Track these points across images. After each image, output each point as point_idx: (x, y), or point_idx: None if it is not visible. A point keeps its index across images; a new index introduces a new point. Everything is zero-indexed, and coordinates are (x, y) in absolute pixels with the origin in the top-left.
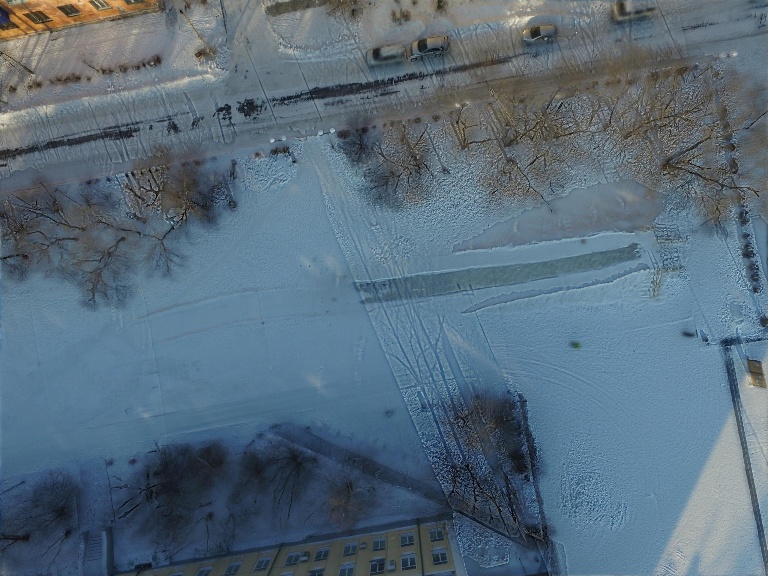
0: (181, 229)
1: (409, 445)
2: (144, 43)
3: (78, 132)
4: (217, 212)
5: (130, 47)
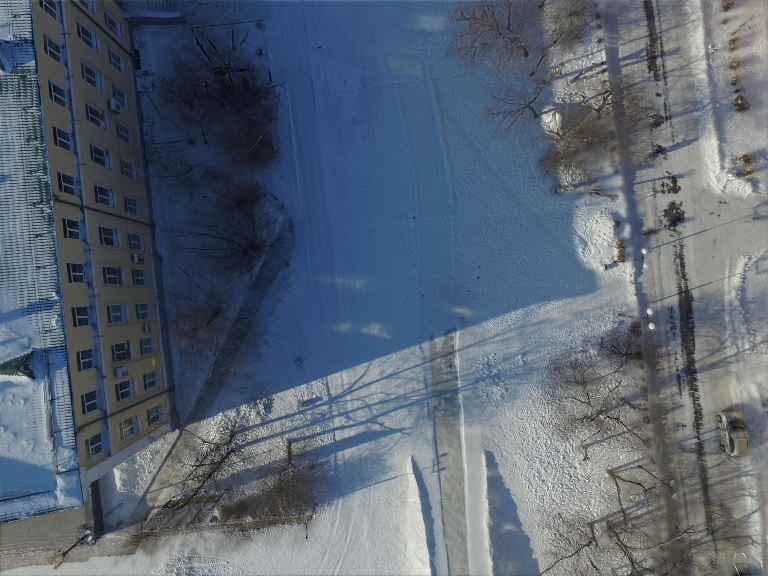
0: (534, 126)
1: (260, 383)
2: (763, 92)
3: (659, 6)
4: (552, 170)
5: (760, 75)
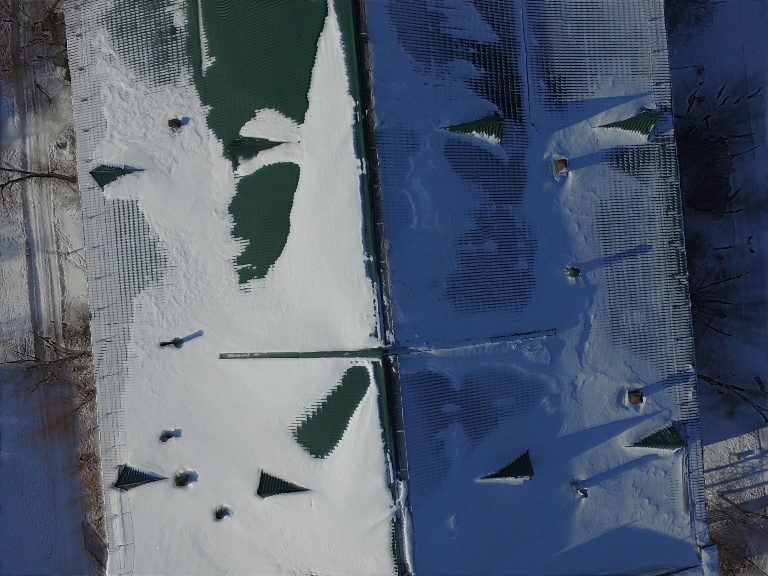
0: None
1: None
2: None
3: None
4: None
5: None
